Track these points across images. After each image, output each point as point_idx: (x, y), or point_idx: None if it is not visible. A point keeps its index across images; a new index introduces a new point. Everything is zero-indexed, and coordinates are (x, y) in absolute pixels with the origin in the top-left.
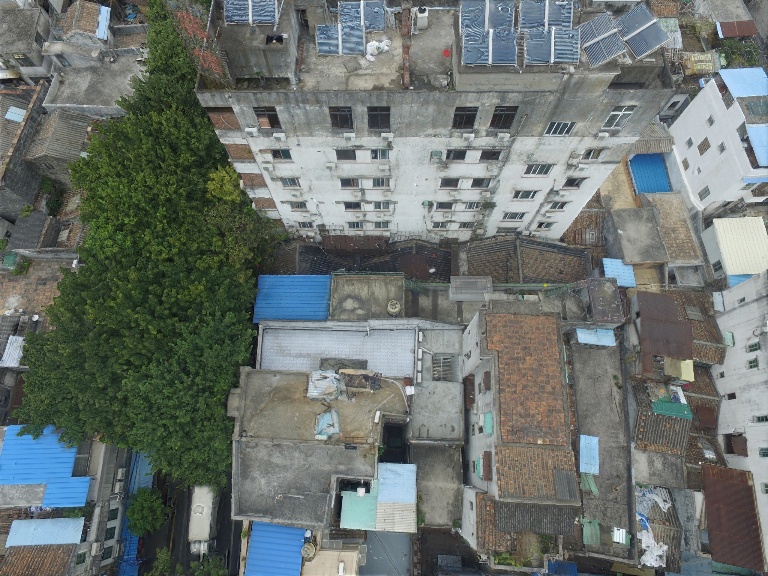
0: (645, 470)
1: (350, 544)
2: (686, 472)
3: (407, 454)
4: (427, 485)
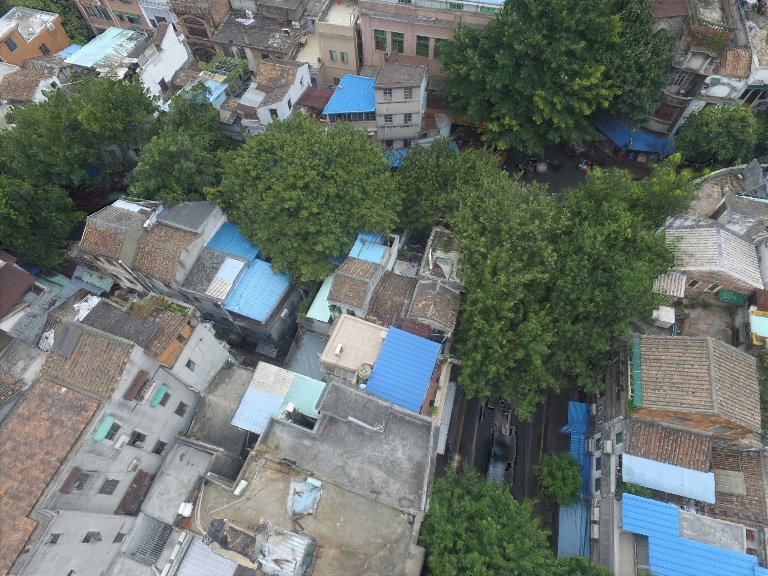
0: (36, 364)
1: (334, 375)
2: (3, 351)
3: (247, 447)
4: (237, 406)
